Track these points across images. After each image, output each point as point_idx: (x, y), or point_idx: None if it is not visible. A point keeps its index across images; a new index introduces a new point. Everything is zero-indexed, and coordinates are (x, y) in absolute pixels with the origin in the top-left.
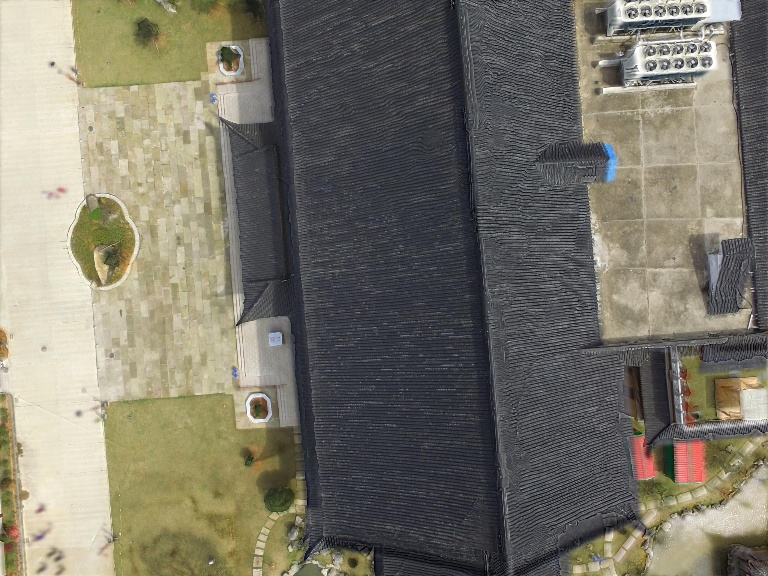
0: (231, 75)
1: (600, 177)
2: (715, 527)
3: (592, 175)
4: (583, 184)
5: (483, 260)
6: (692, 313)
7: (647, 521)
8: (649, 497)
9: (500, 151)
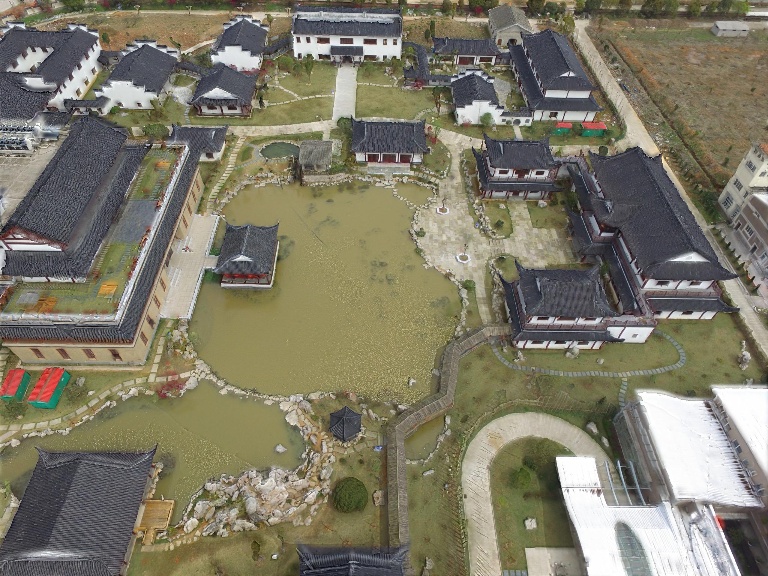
0: None
1: None
2: (54, 448)
3: None
4: None
5: None
6: None
7: (3, 439)
8: (15, 422)
9: None
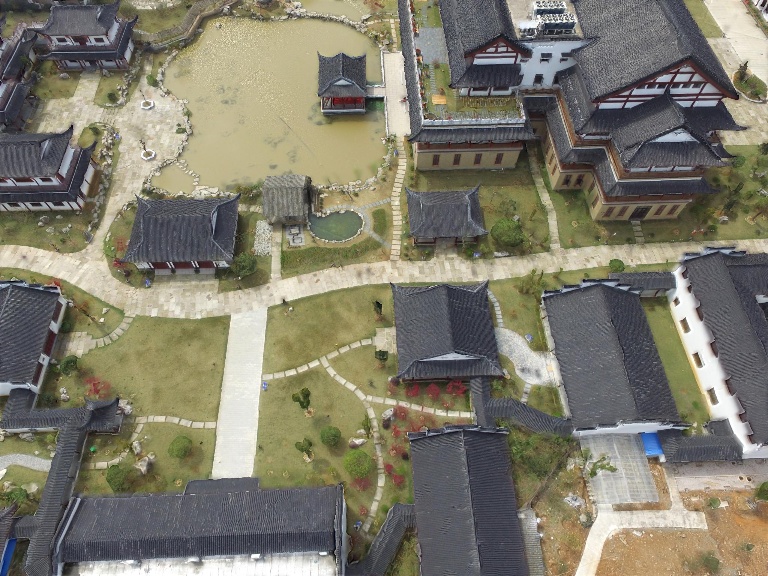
0: None
1: None
2: None
3: None
4: None
5: None
6: None
7: None
8: None
9: None
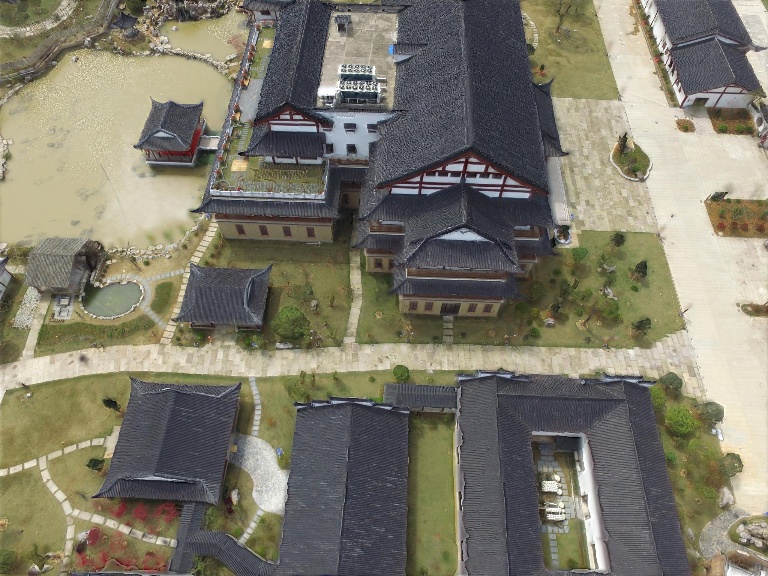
0: None
1: None
2: None
3: None
4: None
5: None
6: (357, 17)
7: None
8: None
9: None
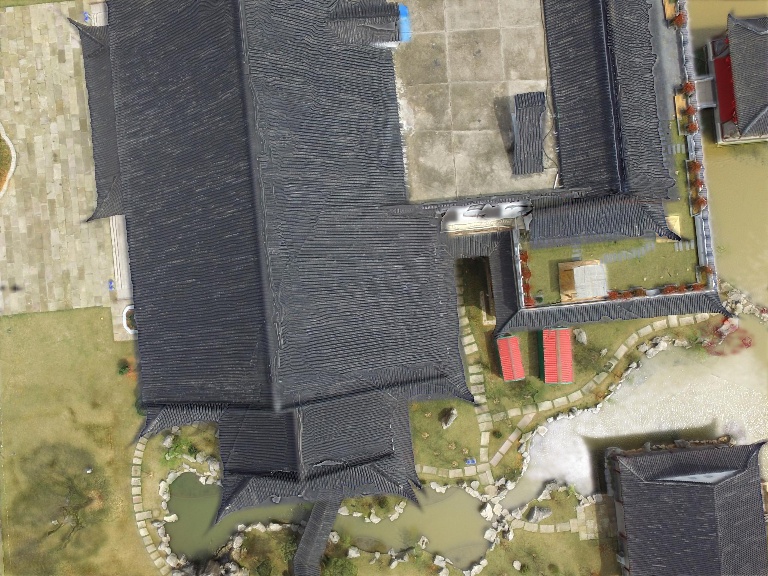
0: None
1: (404, 42)
2: (592, 431)
3: (396, 40)
4: (387, 49)
5: (258, 103)
6: (498, 174)
7: (524, 426)
8: (525, 402)
9: (283, 4)
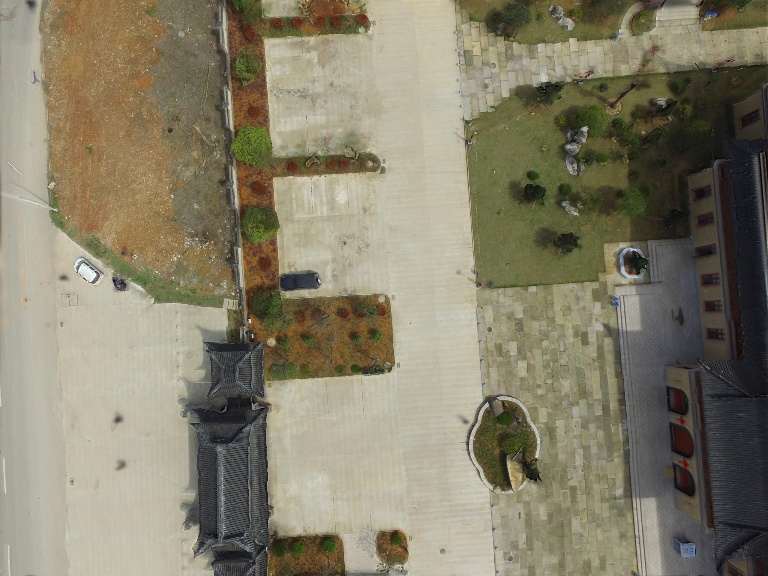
0: (632, 278)
1: None
2: None
3: None
4: None
5: None
6: None
7: None
8: None
9: None
